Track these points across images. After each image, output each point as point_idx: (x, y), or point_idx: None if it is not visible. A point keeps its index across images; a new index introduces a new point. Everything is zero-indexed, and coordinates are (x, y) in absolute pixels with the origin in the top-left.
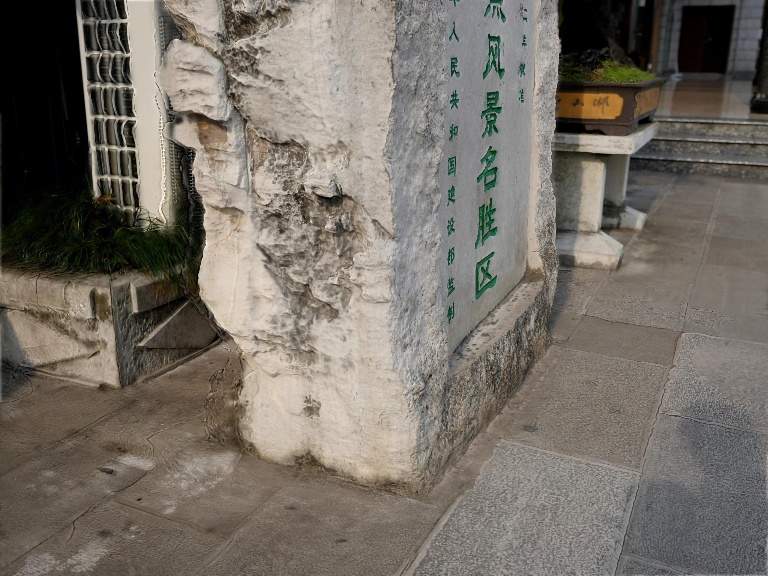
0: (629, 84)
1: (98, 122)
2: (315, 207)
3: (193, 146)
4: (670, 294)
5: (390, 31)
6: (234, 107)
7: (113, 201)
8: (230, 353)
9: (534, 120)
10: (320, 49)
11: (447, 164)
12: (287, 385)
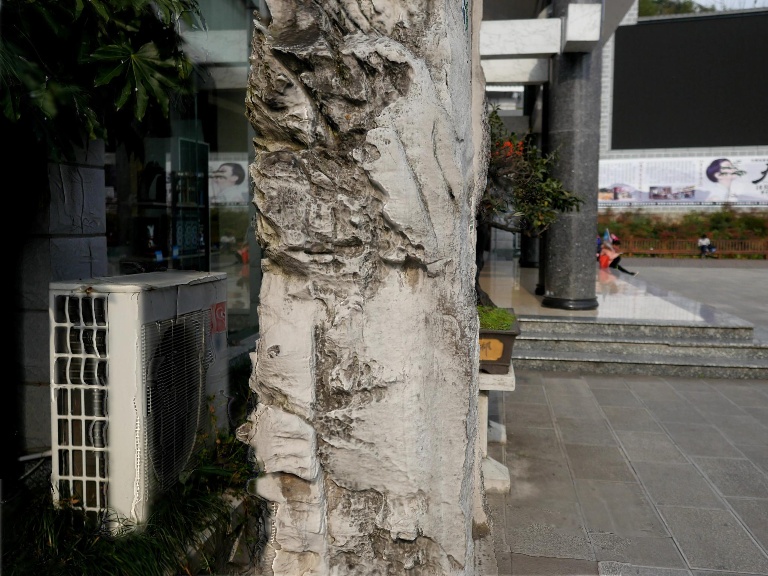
0: (508, 332)
1: (62, 424)
2: (388, 545)
3: (276, 500)
4: (566, 517)
5: (465, 399)
6: (320, 464)
7: (75, 504)
8: None
9: None
10: (410, 418)
11: None
12: None
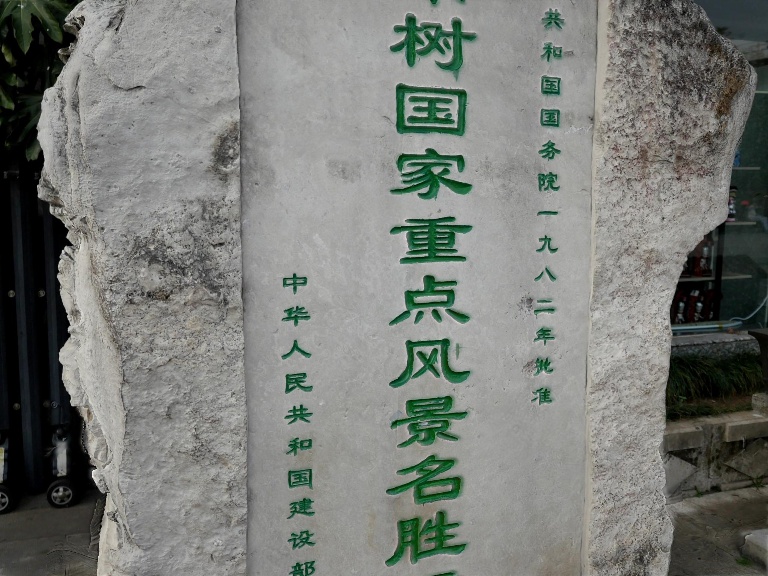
0: None
1: None
2: None
3: None
4: None
5: (119, 367)
6: None
7: None
8: None
9: (588, 422)
10: (89, 371)
11: (285, 477)
12: None
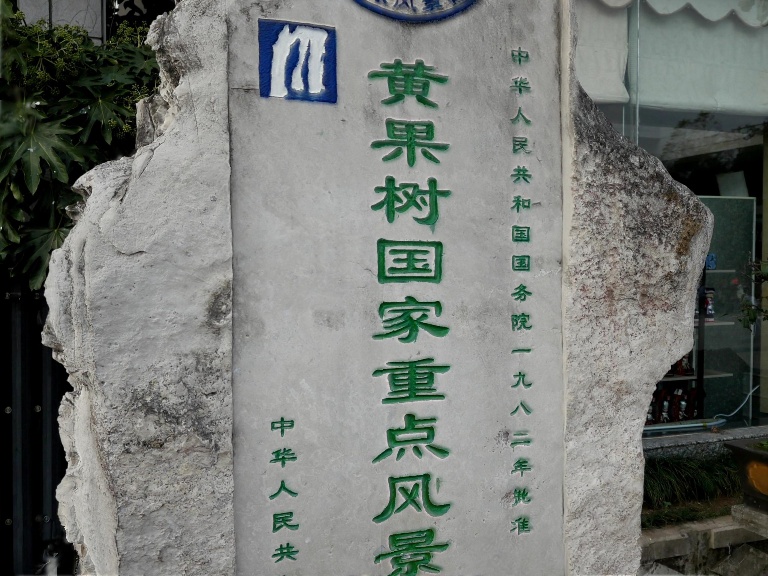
0: None
1: None
2: None
3: None
4: None
5: (114, 513)
6: None
7: None
8: None
9: (567, 550)
10: (85, 514)
11: None
12: None
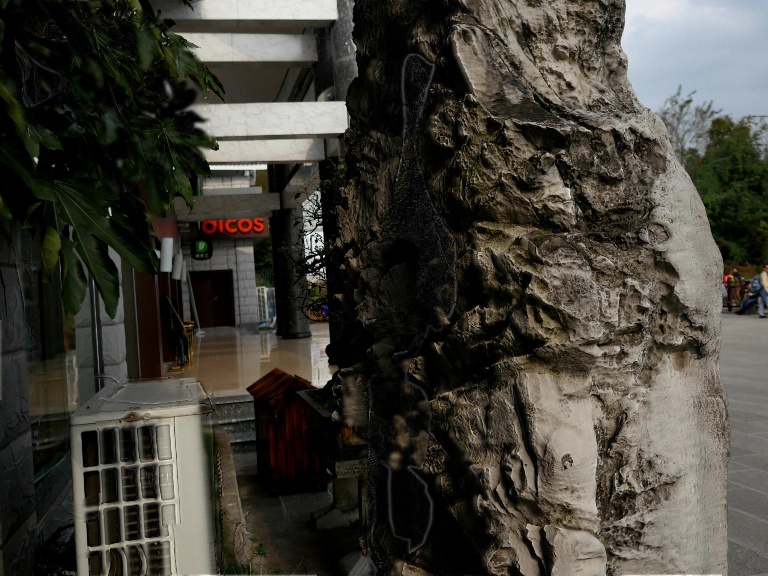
0: None
1: None
2: None
3: None
4: None
5: (720, 482)
6: None
7: None
8: None
9: None
10: (691, 512)
11: None
12: None
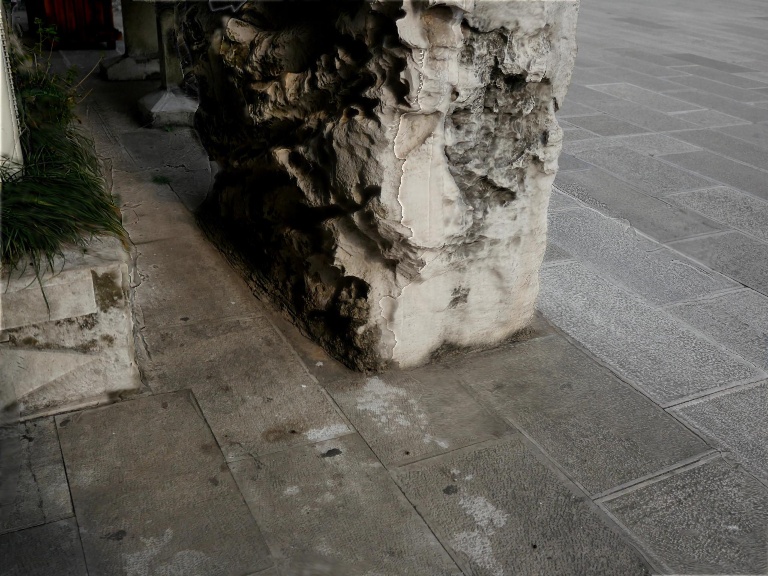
0: None
1: None
2: (501, 95)
3: (423, 46)
4: None
5: None
6: None
7: None
8: (367, 278)
9: None
10: None
11: None
12: (433, 286)
